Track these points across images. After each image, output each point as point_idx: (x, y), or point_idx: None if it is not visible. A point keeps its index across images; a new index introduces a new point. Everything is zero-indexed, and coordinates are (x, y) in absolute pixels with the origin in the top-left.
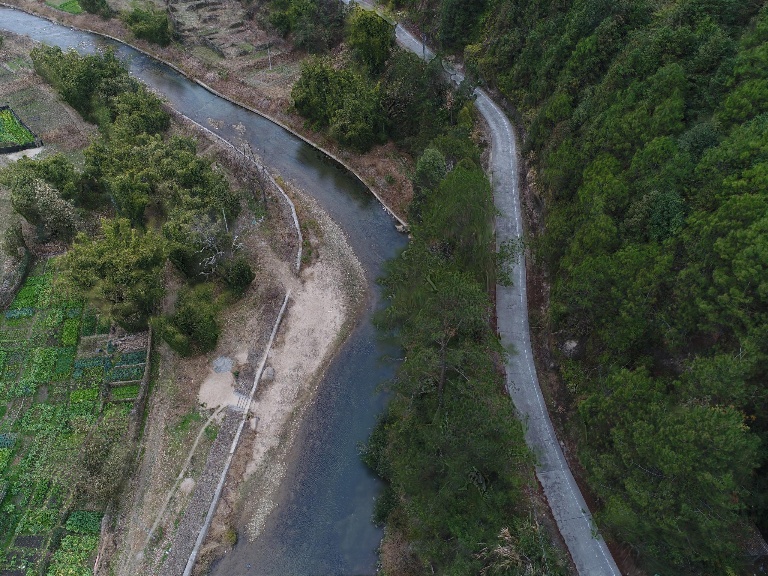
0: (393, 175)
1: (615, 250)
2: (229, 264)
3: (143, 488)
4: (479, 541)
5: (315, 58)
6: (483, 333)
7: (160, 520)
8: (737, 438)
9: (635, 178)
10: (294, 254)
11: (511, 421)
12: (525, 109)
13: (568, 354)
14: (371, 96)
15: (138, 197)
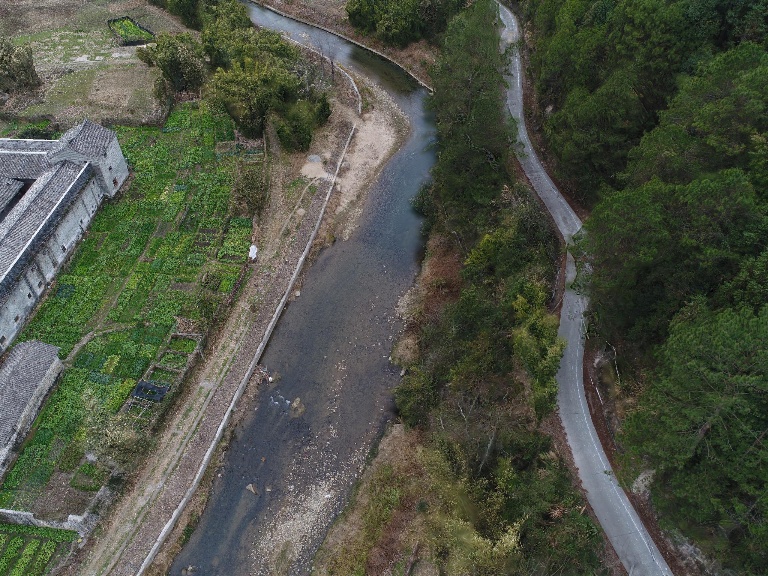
0: (426, 59)
1: (574, 34)
2: None
3: (273, 212)
4: (491, 199)
5: None
6: (494, 72)
7: (287, 226)
8: (627, 91)
9: (589, 1)
10: (356, 105)
11: (510, 117)
12: (525, 3)
13: (547, 118)
14: (409, 3)
15: None
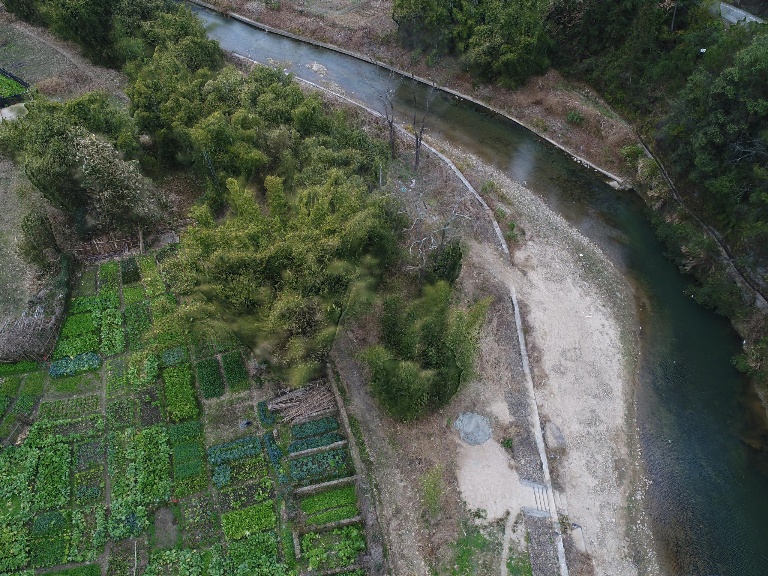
0: (581, 112)
1: None
2: (406, 252)
3: None
4: None
5: None
6: None
7: None
8: None
9: None
10: (490, 231)
11: None
12: None
13: None
14: (528, 3)
15: (247, 151)
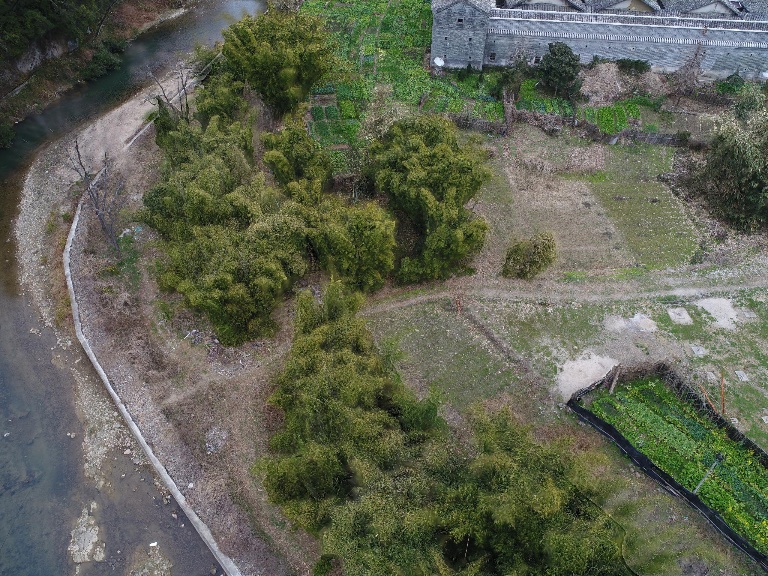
0: None
1: None
2: None
3: None
4: None
5: None
6: None
7: None
8: None
9: None
10: None
11: None
12: None
13: None
14: None
15: None
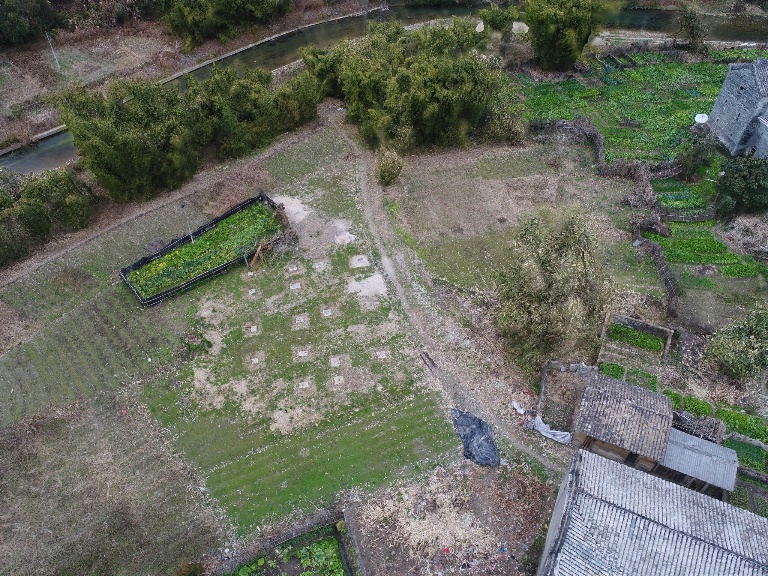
0: None
1: None
2: None
3: None
4: None
5: (61, 31)
6: None
7: None
8: None
9: None
10: None
11: None
12: None
13: None
14: None
15: None
